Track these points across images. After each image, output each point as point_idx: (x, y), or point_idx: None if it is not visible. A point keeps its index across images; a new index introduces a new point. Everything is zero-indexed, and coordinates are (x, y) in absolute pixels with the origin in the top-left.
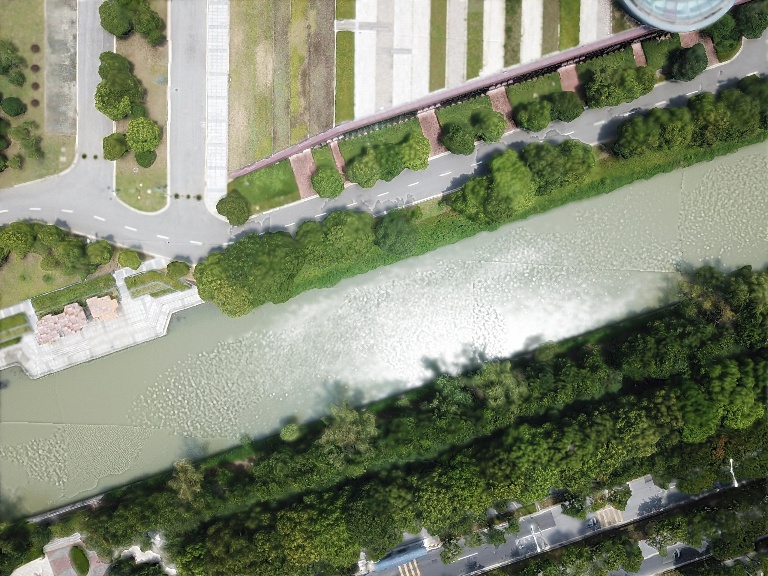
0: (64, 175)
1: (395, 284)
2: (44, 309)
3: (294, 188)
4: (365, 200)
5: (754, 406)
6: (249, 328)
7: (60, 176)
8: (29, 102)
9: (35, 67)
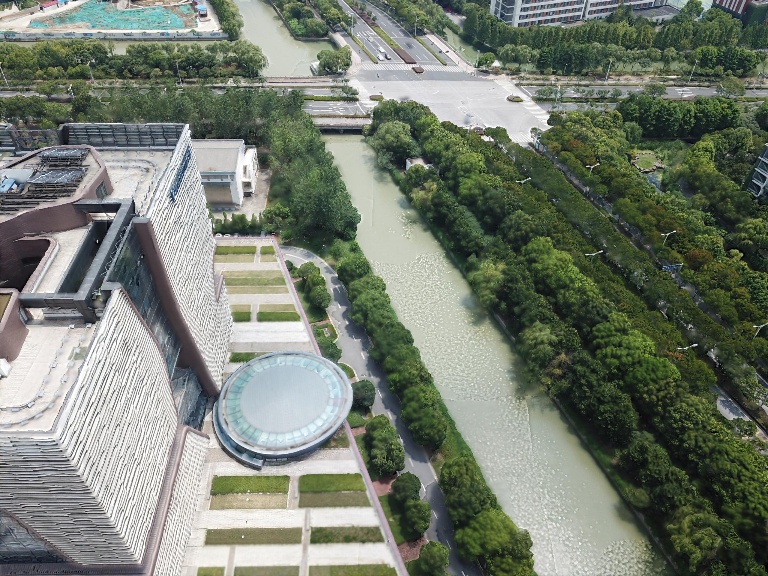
0: None
1: None
2: None
3: None
4: None
5: (634, 335)
6: None
7: None
8: None
9: None
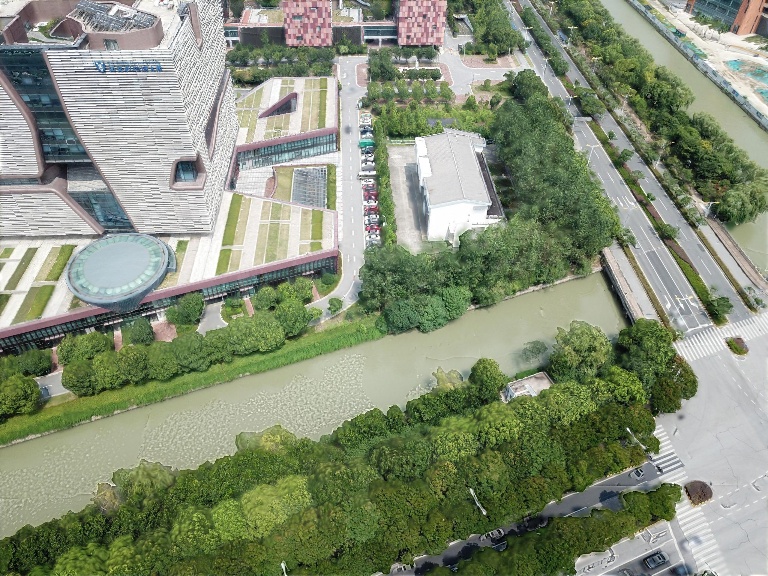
0: None
1: None
2: None
3: None
4: None
5: (91, 573)
6: None
7: None
8: None
9: None
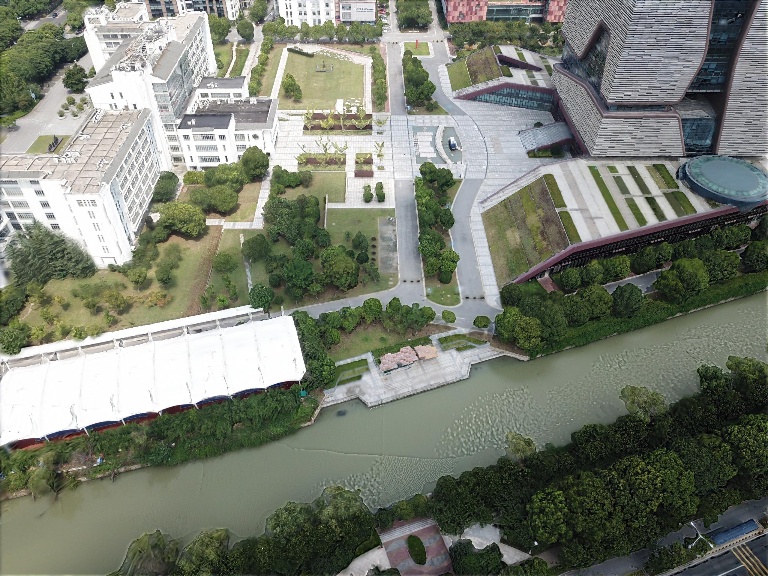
0: (391, 291)
1: (628, 355)
2: (381, 356)
3: (544, 291)
4: None
5: None
6: (530, 376)
7: (389, 291)
8: (370, 259)
9: (374, 245)
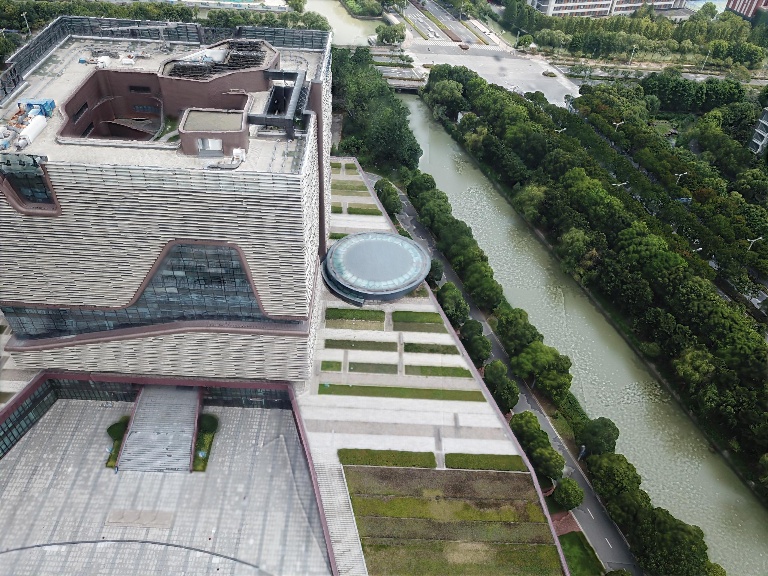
0: None
1: None
2: None
3: (574, 535)
4: (567, 475)
5: (651, 237)
6: None
7: None
8: None
9: None
